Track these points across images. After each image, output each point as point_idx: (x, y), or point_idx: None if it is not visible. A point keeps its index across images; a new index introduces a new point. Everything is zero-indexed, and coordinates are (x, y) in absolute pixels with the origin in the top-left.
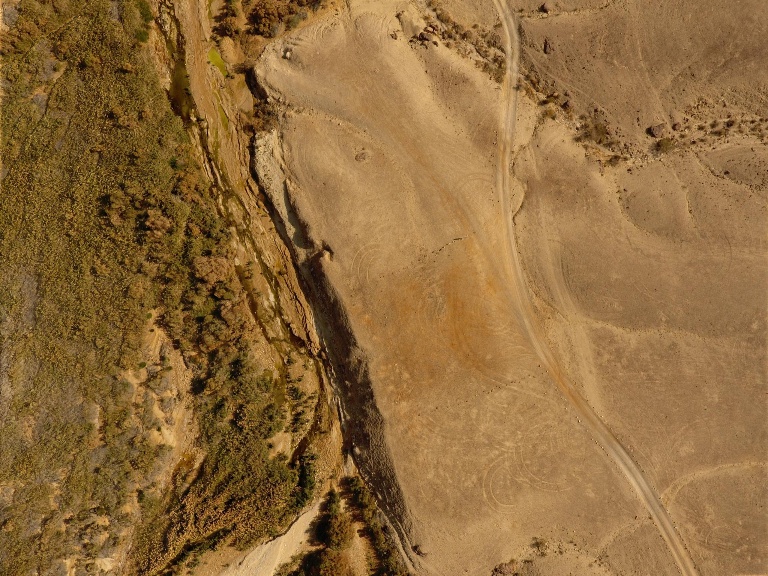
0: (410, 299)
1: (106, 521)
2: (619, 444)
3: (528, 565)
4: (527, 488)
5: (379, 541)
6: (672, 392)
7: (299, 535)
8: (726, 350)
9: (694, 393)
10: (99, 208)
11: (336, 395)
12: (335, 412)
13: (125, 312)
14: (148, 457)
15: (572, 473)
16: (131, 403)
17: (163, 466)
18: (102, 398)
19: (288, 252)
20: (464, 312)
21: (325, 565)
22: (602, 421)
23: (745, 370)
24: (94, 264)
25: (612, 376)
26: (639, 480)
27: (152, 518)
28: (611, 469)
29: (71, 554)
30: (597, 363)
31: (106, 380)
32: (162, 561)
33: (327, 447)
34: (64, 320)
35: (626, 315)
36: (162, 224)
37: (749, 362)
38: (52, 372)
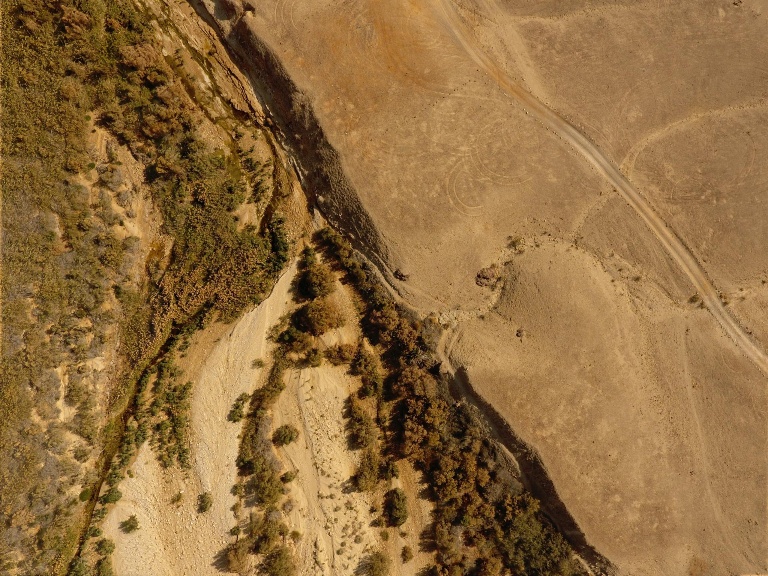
0: (339, 33)
1: (88, 323)
2: (569, 125)
3: (509, 266)
4: (490, 186)
5: (361, 278)
6: (609, 63)
7: (283, 296)
8: (651, 12)
9: (630, 58)
10: (13, 21)
11: (290, 156)
12: (293, 174)
13: (62, 115)
14: (116, 250)
15: (530, 163)
16: (88, 205)
17: (133, 257)
18: (57, 204)
19: (213, 31)
20: (394, 34)
21: (312, 309)
22: (549, 107)
23: (673, 26)
24: (20, 75)
25: (549, 63)
26: (596, 156)
27: (134, 312)
28: (567, 151)
29: (60, 362)
30: (532, 55)
31: (58, 186)
32: (152, 346)
33: (292, 208)
34: (2, 136)
35: (550, 3)
36: (79, 17)
37: (675, 17)
38: (1, 189)
